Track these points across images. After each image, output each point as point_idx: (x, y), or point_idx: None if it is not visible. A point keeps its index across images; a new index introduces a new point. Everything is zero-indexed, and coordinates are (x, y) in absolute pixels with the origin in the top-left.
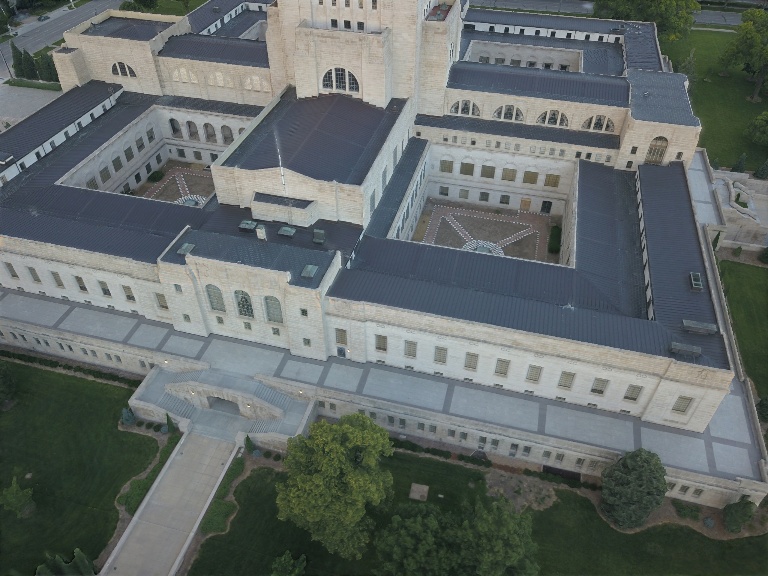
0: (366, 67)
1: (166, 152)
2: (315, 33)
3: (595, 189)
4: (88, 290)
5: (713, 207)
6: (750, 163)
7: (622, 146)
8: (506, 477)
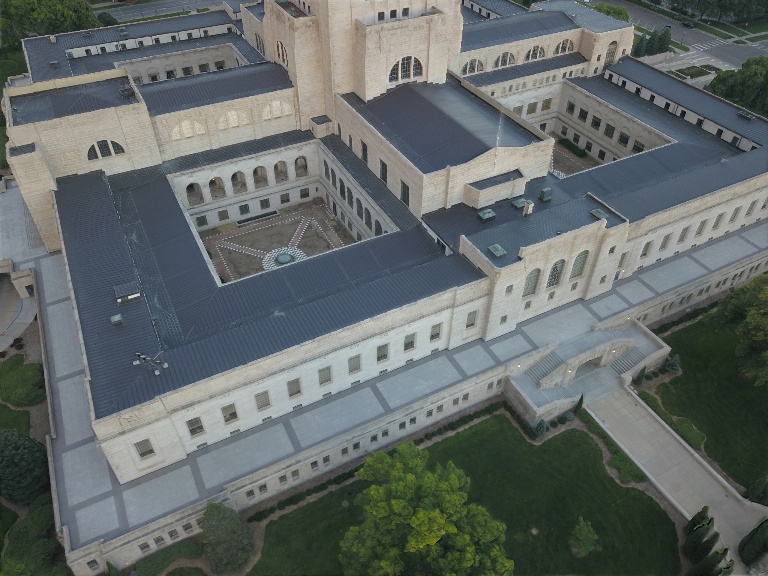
0: (433, 48)
1: None
2: (385, 28)
3: (602, 94)
4: (390, 355)
5: None
6: None
7: (592, 57)
8: None
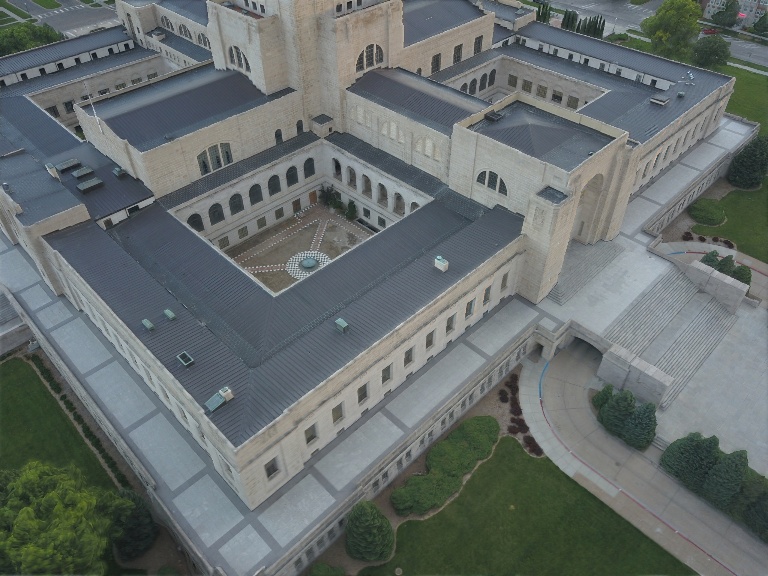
0: None
1: None
2: None
3: None
4: None
5: None
6: None
7: None
8: None
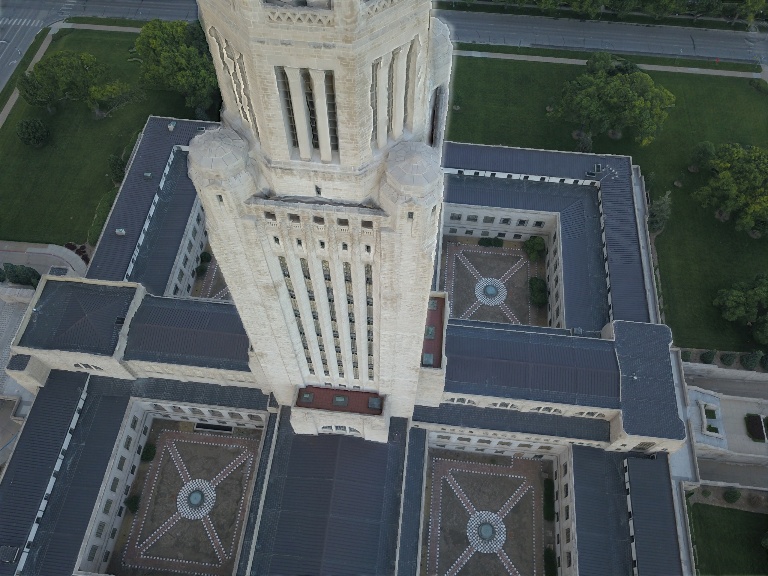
0: (368, 430)
1: (150, 417)
2: (313, 412)
3: (589, 493)
4: None
5: (688, 448)
6: (718, 337)
7: (613, 444)
8: None
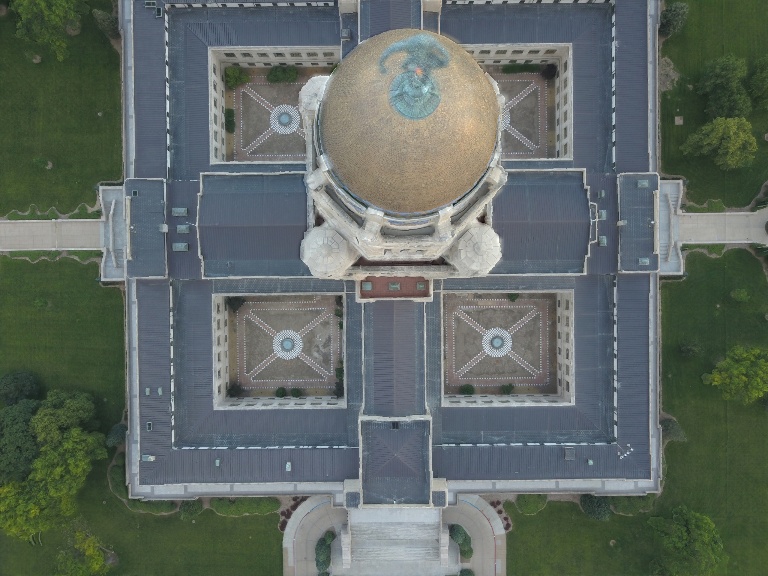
0: None
1: None
2: None
3: (475, 33)
4: None
5: None
6: None
7: None
8: (661, 81)
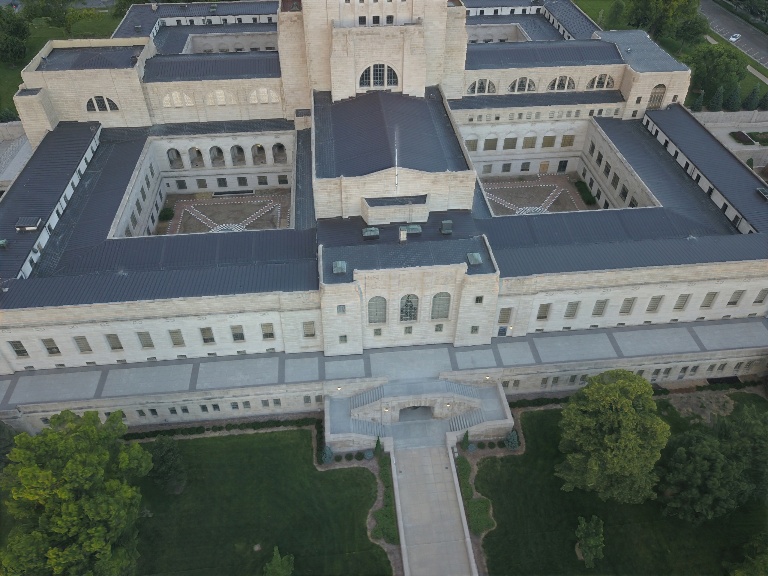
0: (408, 59)
1: (163, 187)
2: (354, 32)
3: (622, 139)
4: (216, 340)
5: None
6: None
7: (629, 98)
8: (686, 398)
